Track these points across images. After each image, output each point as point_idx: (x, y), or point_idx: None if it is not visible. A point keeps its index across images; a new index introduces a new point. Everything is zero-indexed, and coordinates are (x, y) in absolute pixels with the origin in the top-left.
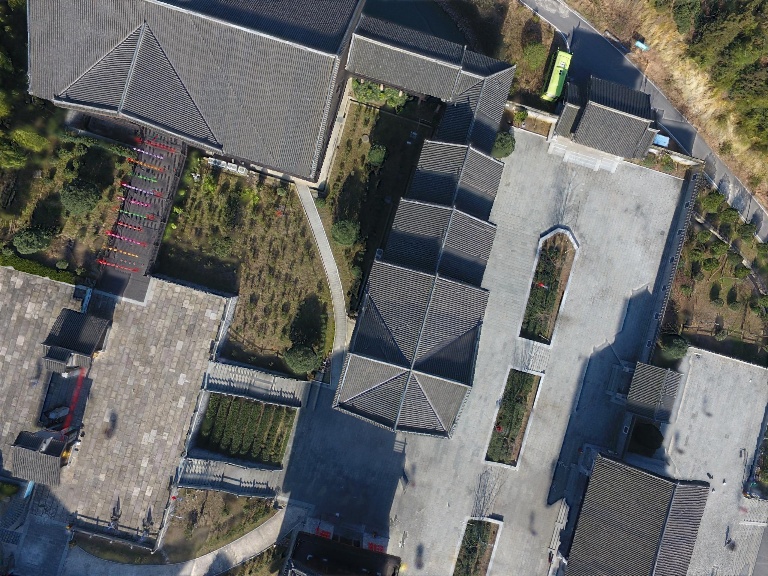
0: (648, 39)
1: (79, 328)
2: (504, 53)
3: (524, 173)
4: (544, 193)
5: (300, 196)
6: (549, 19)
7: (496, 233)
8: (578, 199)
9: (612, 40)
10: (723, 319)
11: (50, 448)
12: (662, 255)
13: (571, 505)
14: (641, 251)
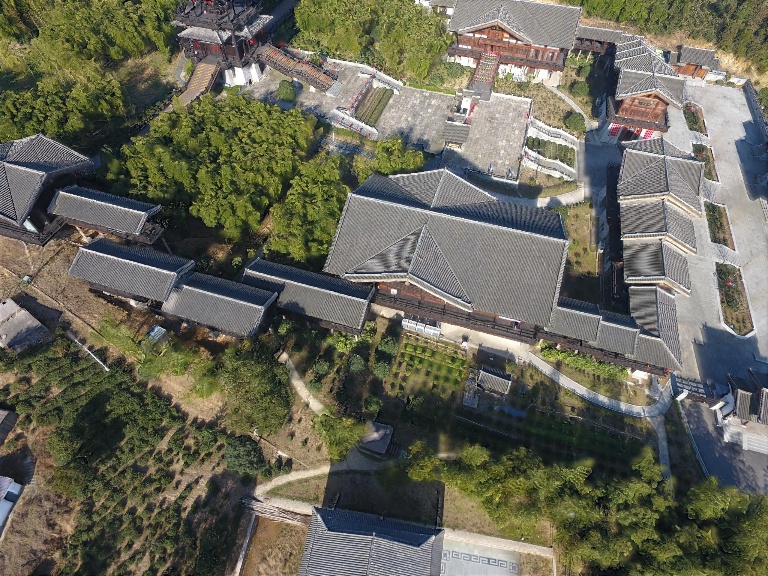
0: None
1: None
2: None
3: None
4: None
5: (549, 88)
6: None
7: None
8: None
9: None
10: None
11: None
12: (750, 111)
13: (767, 200)
14: (737, 110)
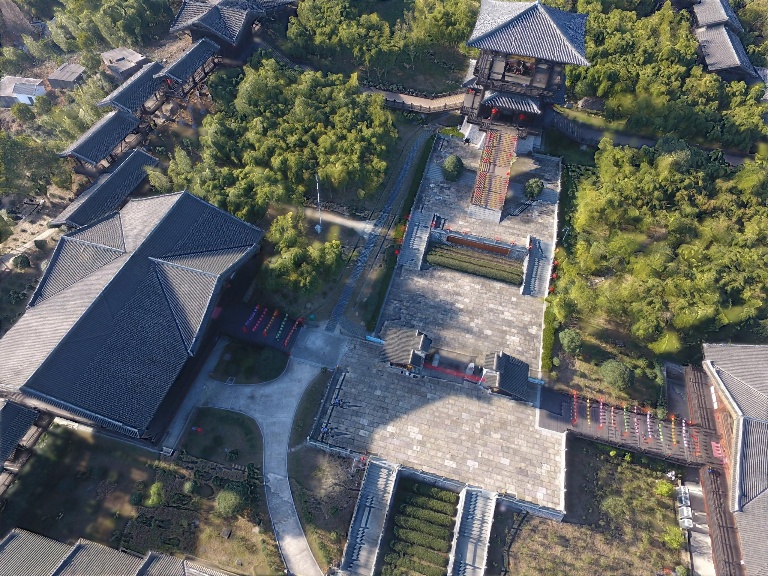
0: None
1: (517, 377)
2: None
3: None
4: None
5: None
6: None
7: None
8: None
9: None
10: None
11: (416, 356)
12: None
13: None
14: None
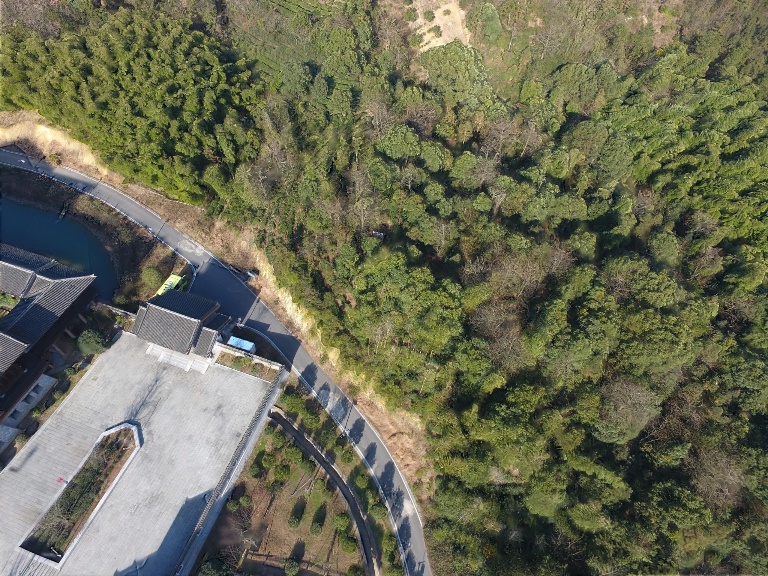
0: (261, 271)
1: None
2: (132, 275)
3: (116, 369)
4: (128, 388)
5: None
6: (185, 256)
7: (61, 425)
8: (160, 396)
9: (234, 271)
10: (305, 547)
11: None
12: None
13: None
14: (210, 453)
